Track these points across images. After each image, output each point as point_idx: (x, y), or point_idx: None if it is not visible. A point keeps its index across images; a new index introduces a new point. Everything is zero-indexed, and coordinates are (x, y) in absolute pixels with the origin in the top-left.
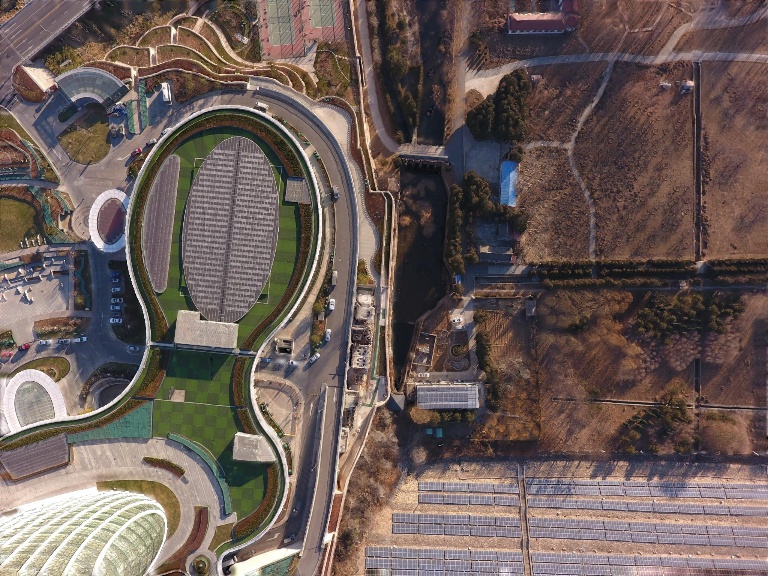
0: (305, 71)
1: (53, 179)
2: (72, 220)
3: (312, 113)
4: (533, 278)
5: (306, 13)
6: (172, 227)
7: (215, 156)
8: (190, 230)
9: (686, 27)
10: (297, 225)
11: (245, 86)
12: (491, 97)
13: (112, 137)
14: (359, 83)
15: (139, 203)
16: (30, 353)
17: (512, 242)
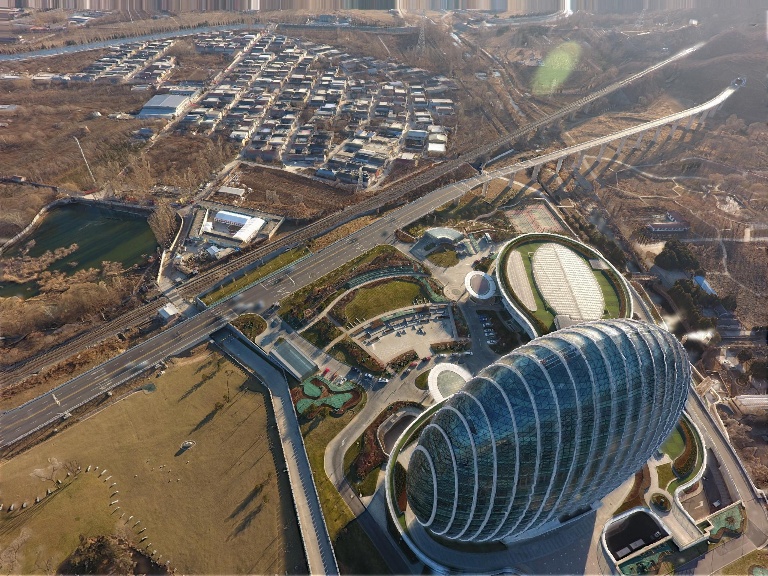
0: None
1: (429, 272)
2: (444, 292)
3: None
4: (761, 339)
5: None
6: (528, 280)
7: (541, 251)
8: (540, 281)
9: (749, 229)
10: (607, 279)
11: None
12: (667, 248)
13: (460, 256)
14: None
15: (503, 270)
16: (431, 363)
17: (731, 316)
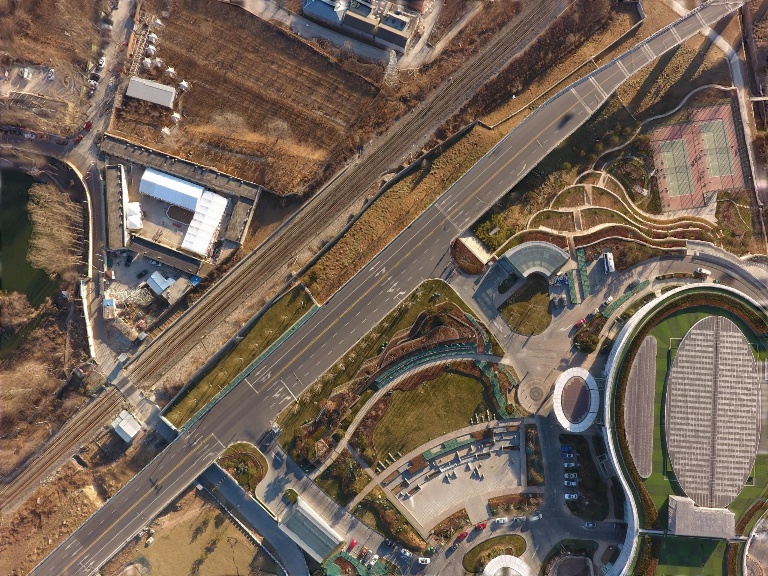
0: (714, 224)
1: (501, 354)
2: (518, 393)
3: (754, 277)
4: None
5: (704, 162)
6: (653, 410)
7: (693, 336)
8: (672, 413)
9: None
10: None
11: (684, 252)
12: None
13: (554, 308)
14: (763, 232)
15: (620, 387)
16: (485, 531)
17: None
